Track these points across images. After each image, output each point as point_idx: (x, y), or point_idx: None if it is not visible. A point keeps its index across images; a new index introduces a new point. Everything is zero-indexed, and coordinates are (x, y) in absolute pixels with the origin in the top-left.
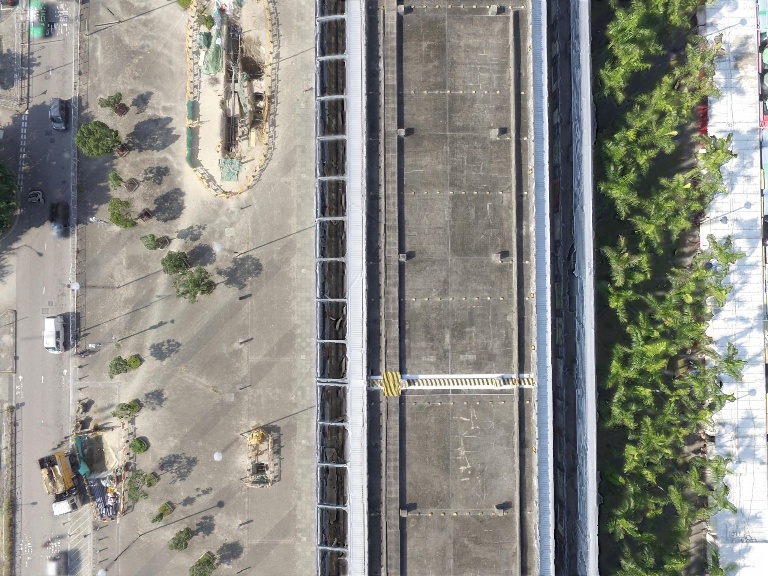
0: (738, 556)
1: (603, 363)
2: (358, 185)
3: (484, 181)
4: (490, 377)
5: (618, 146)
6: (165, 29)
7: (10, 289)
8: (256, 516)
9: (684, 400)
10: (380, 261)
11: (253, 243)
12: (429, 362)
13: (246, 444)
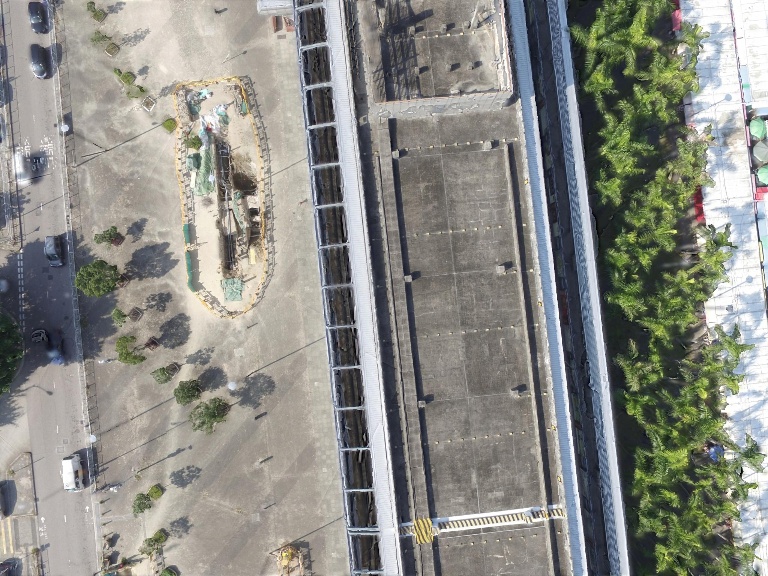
0: None
1: (626, 469)
2: (370, 333)
3: (495, 317)
4: (519, 512)
5: (620, 253)
6: (153, 154)
7: (23, 431)
8: None
9: (707, 490)
10: (399, 408)
11: (263, 361)
12: (458, 503)
13: (276, 562)
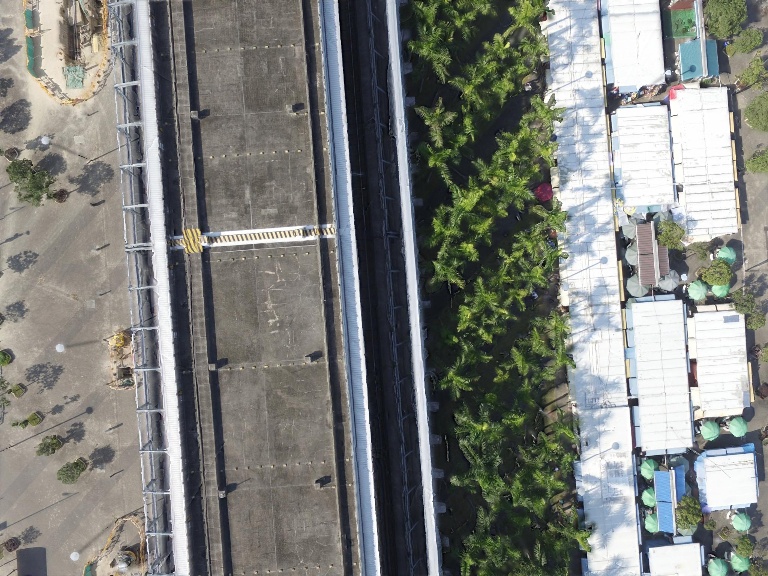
0: (598, 421)
1: (428, 224)
2: (149, 47)
3: (275, 35)
4: (293, 229)
5: (429, 6)
6: None
7: None
8: (125, 419)
9: (520, 262)
10: (175, 122)
11: (103, 149)
12: (231, 219)
13: None
